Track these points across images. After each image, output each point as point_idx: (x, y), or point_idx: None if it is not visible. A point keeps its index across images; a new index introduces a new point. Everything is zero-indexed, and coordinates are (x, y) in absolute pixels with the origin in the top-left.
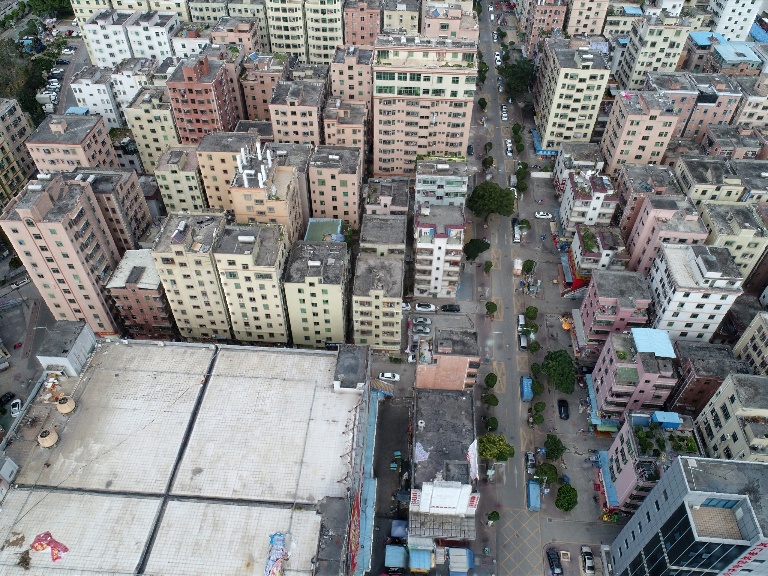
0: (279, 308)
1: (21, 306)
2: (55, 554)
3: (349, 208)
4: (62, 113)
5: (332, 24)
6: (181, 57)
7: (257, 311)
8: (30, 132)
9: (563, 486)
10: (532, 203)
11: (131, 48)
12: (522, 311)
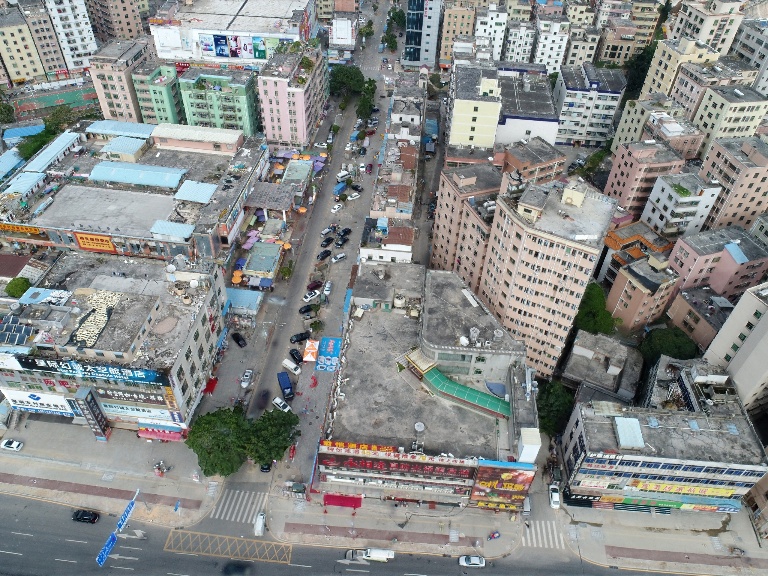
0: None
1: (152, 6)
2: (199, 21)
3: None
4: None
5: None
6: None
7: None
8: None
9: None
10: None
11: None
12: None
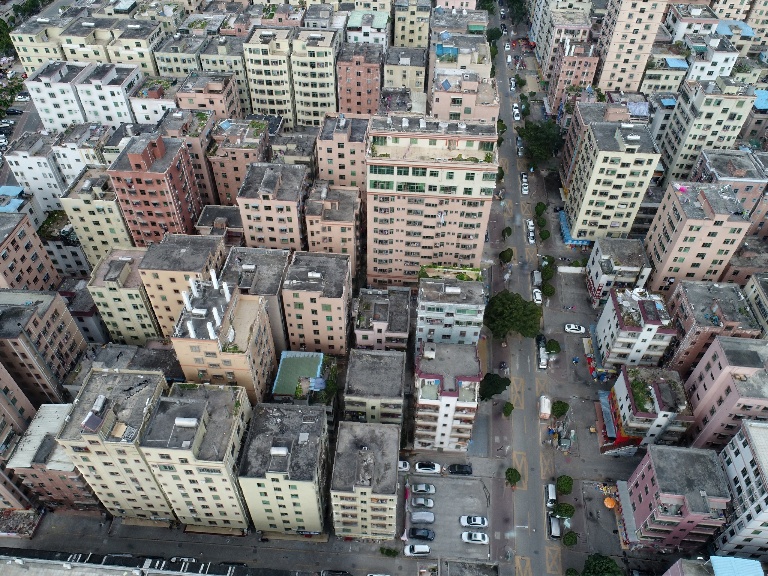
0: (233, 499)
1: None
2: None
3: (334, 333)
4: (5, 178)
5: (323, 79)
6: (141, 121)
7: (205, 500)
8: None
9: None
10: (560, 310)
11: (83, 108)
12: (551, 475)
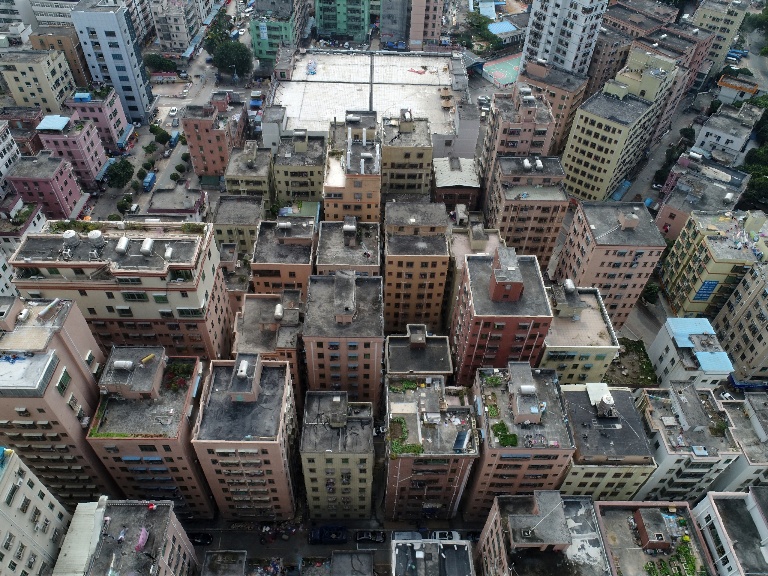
0: None
1: None
2: None
3: None
4: None
5: None
6: None
7: None
8: (760, 352)
9: (156, 128)
10: None
11: None
12: None
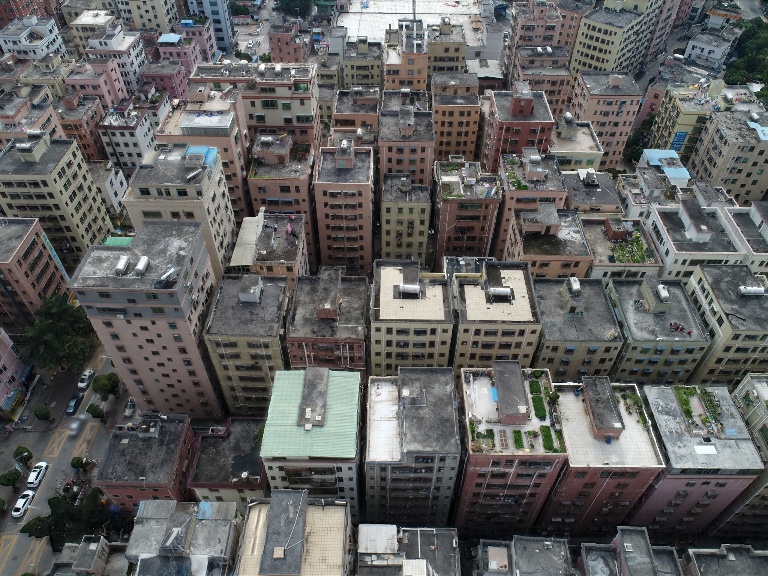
0: None
1: None
2: None
3: None
4: None
5: None
6: None
7: None
8: None
9: (240, 53)
10: None
11: None
12: None
